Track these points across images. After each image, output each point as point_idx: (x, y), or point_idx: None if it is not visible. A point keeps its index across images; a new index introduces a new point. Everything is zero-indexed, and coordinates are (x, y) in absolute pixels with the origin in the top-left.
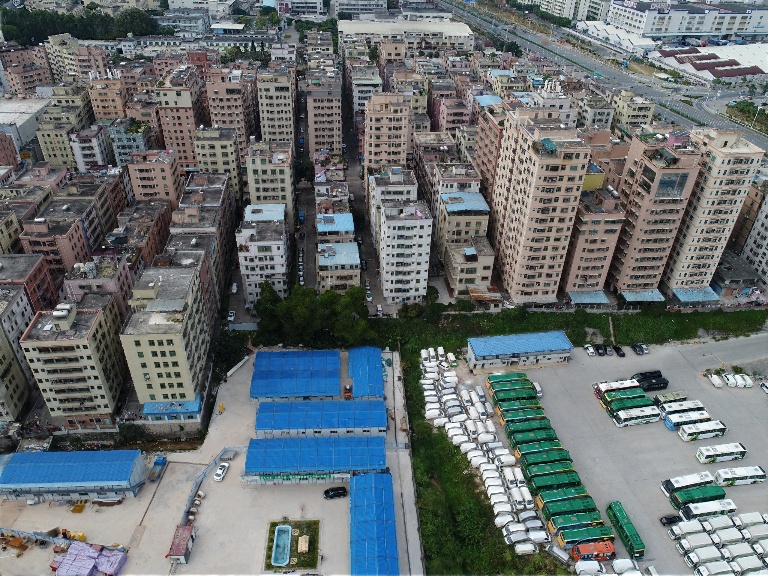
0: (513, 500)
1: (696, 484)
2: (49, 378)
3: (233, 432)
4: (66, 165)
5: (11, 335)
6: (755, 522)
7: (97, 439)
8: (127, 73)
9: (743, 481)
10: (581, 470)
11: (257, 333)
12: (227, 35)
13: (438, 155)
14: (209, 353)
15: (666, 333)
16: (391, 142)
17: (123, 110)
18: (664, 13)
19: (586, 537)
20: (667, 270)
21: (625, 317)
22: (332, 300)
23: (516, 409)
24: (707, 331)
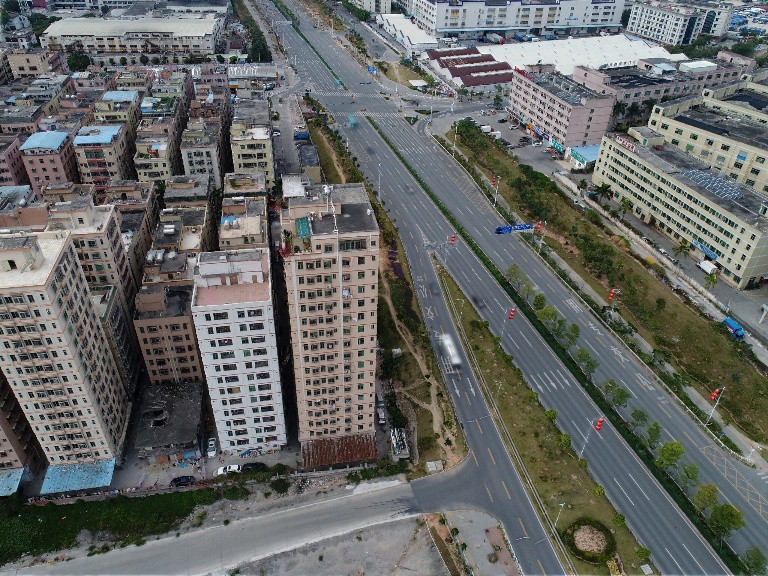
0: None
1: None
2: None
3: None
4: None
5: None
6: None
7: None
8: None
9: None
10: None
11: None
12: None
13: None
14: None
15: (18, 544)
16: None
17: None
18: (457, 5)
19: None
20: None
21: None
22: None
23: None
24: (93, 533)
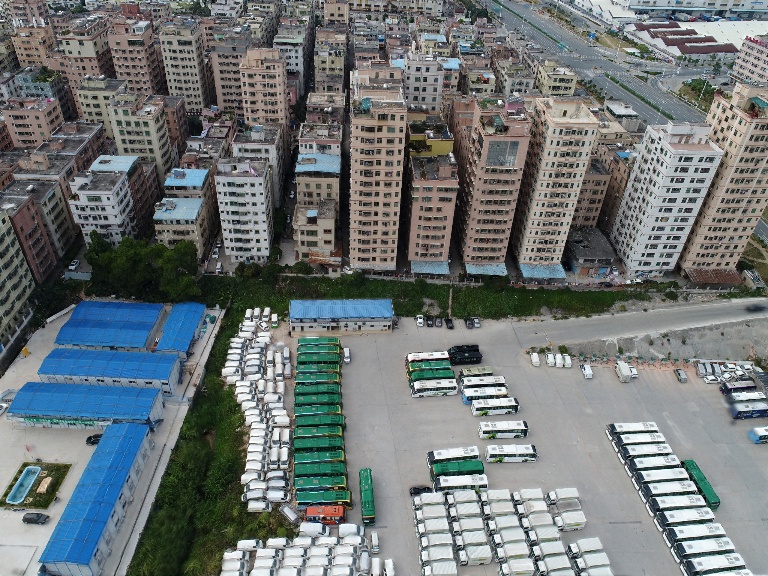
0: (268, 459)
1: (460, 458)
2: None
3: (28, 375)
4: None
5: None
6: (500, 499)
7: None
8: (63, 23)
9: (513, 459)
10: (354, 436)
11: (92, 283)
12: None
13: (321, 116)
14: (31, 298)
15: (506, 308)
16: (267, 100)
17: None
18: None
19: (319, 500)
20: (518, 244)
21: (466, 290)
22: (157, 253)
23: (311, 372)
24: (550, 309)
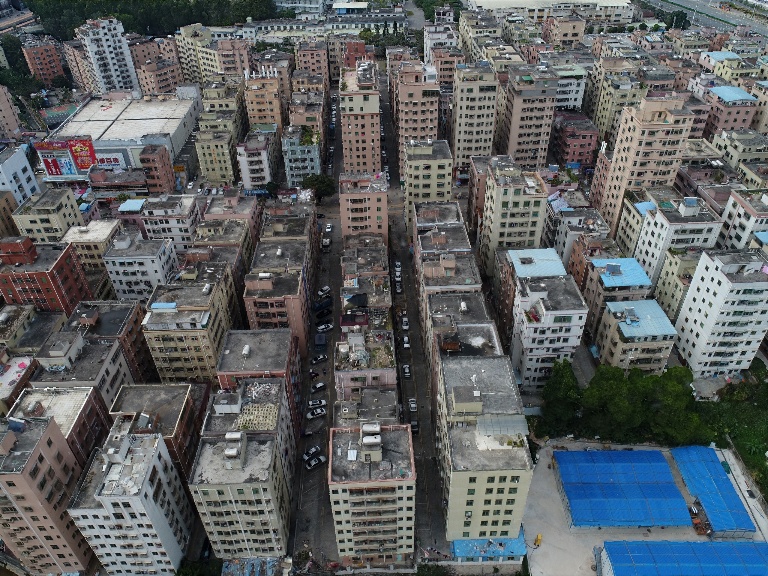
0: None
1: None
2: (351, 520)
3: None
4: (224, 179)
5: (281, 448)
6: None
7: None
8: (273, 68)
9: None
10: None
11: (538, 419)
12: (350, 15)
13: (710, 172)
14: None
15: None
16: (661, 160)
17: (280, 113)
18: None
19: None
20: None
21: None
22: (655, 387)
23: None
24: None
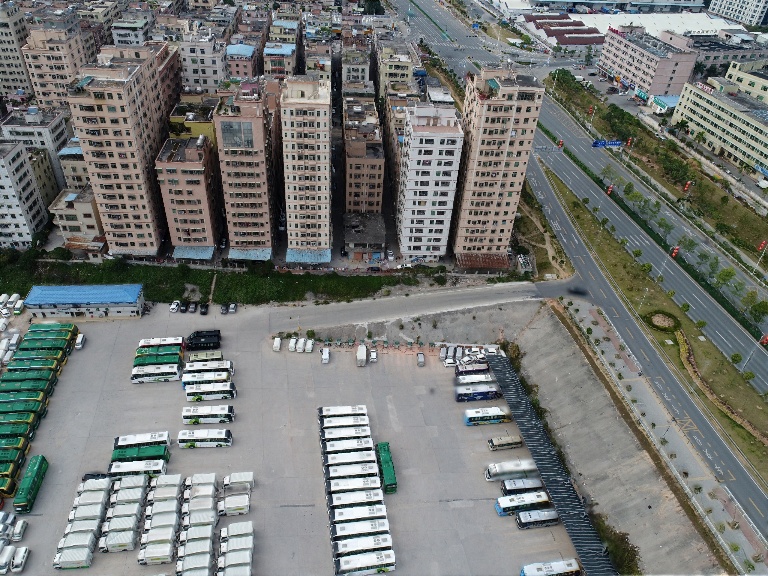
0: None
1: (148, 443)
2: None
3: None
4: None
5: None
6: (167, 484)
7: None
8: None
9: (206, 444)
10: (51, 423)
11: None
12: None
13: None
14: None
15: (268, 294)
16: (57, 82)
17: None
18: None
19: None
20: None
21: (231, 275)
22: None
23: (27, 359)
24: (316, 294)
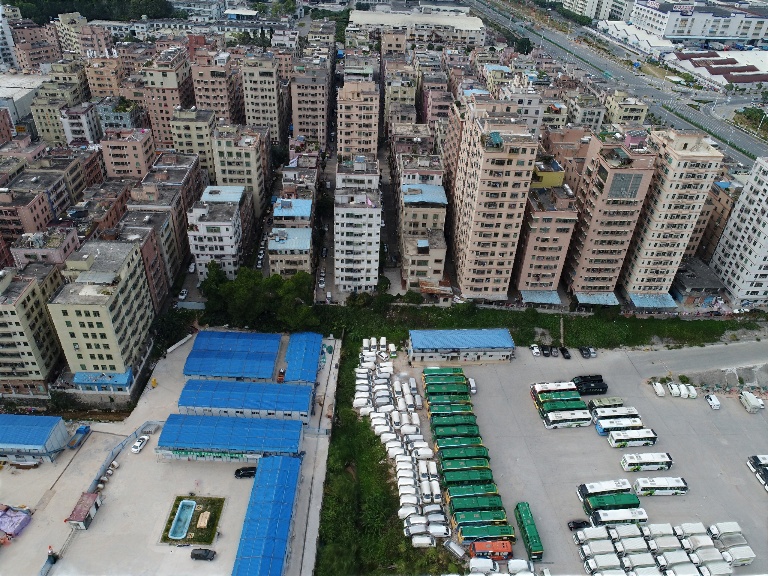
0: (421, 493)
1: (612, 491)
2: None
3: (161, 407)
4: (59, 140)
5: None
6: (664, 533)
7: (31, 405)
8: (128, 53)
9: (663, 492)
10: (499, 469)
11: (205, 312)
12: (240, 21)
13: (411, 146)
14: (151, 329)
15: (618, 338)
16: (361, 131)
17: (118, 89)
18: (687, 15)
19: (485, 535)
20: (626, 274)
21: (577, 319)
22: (276, 284)
23: (444, 403)
24: (662, 339)
